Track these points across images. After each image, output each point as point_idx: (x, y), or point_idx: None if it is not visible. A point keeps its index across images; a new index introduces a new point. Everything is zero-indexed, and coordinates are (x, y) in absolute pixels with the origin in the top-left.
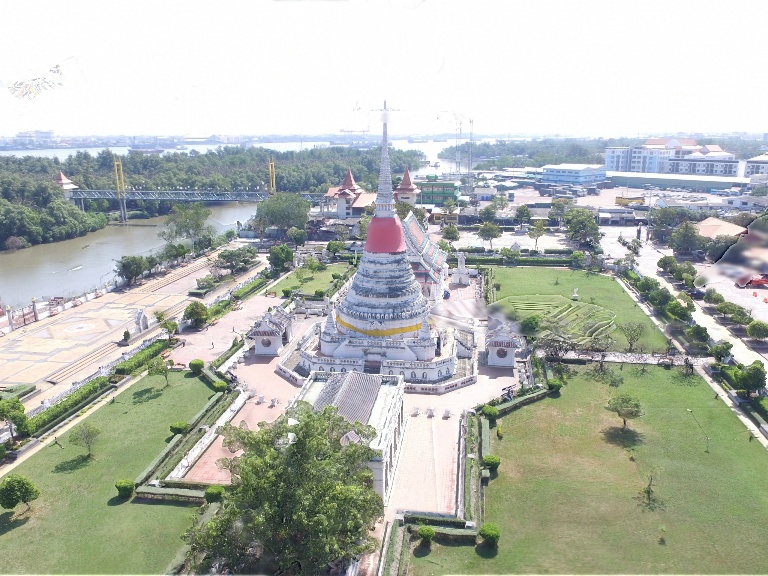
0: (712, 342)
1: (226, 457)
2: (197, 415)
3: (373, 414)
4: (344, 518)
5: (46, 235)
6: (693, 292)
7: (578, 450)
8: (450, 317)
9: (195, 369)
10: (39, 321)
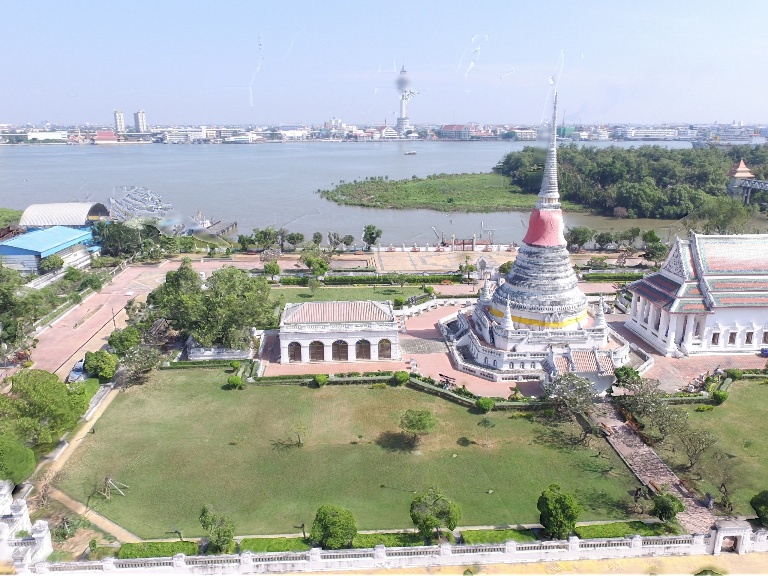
0: None
1: None
2: None
3: None
4: (184, 311)
5: (656, 212)
6: None
7: (363, 419)
8: (29, 180)
9: None
10: (473, 251)
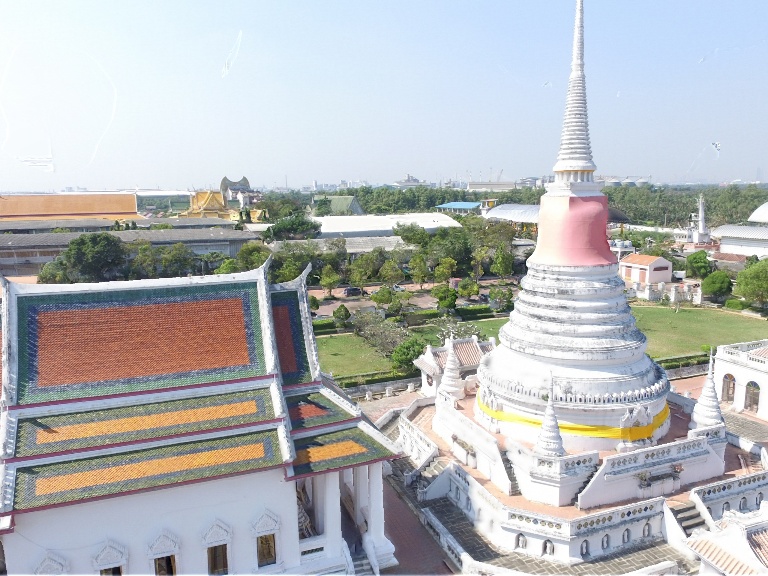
0: None
1: None
2: None
3: None
4: None
5: None
6: None
7: None
8: None
9: None
10: None
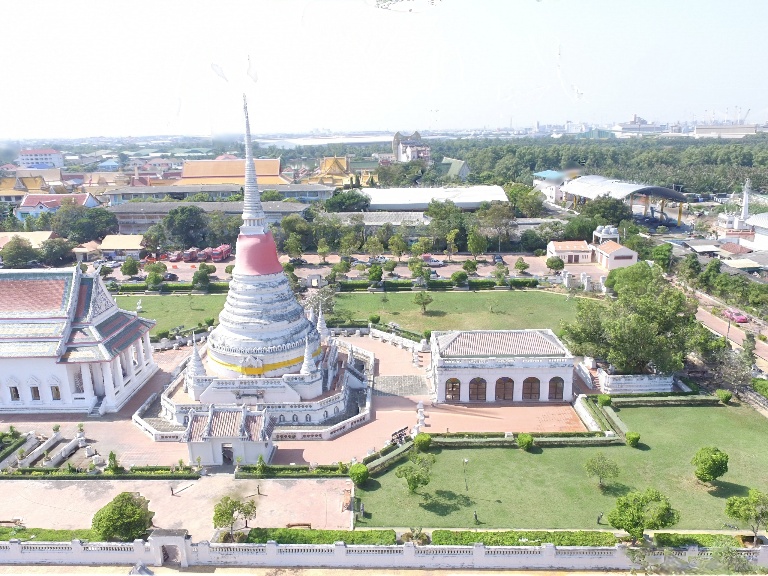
0: (297, 281)
1: (533, 428)
2: (494, 439)
3: None
4: None
5: None
6: (169, 276)
7: None
8: None
9: (368, 475)
10: None
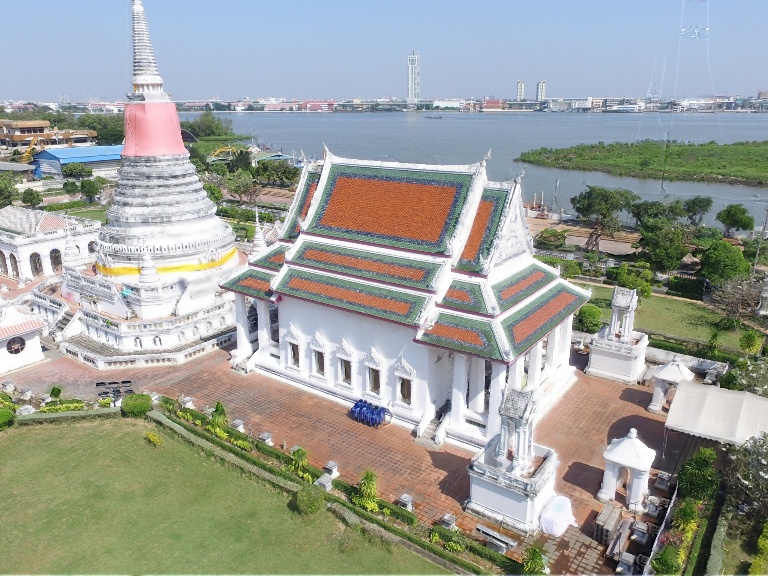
0: None
1: None
2: None
3: (4, 231)
4: None
5: None
6: None
7: None
8: None
9: None
10: None
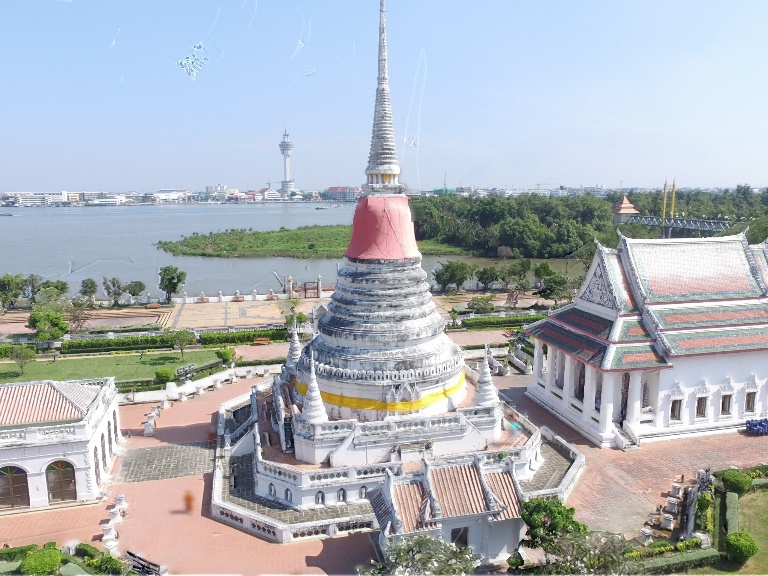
0: None
1: None
2: None
3: None
4: None
5: (543, 250)
6: None
7: None
8: None
9: None
10: None
